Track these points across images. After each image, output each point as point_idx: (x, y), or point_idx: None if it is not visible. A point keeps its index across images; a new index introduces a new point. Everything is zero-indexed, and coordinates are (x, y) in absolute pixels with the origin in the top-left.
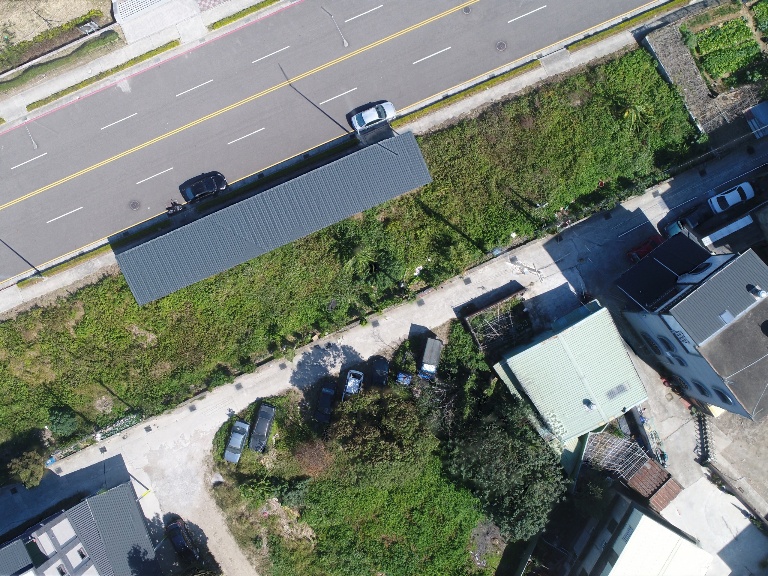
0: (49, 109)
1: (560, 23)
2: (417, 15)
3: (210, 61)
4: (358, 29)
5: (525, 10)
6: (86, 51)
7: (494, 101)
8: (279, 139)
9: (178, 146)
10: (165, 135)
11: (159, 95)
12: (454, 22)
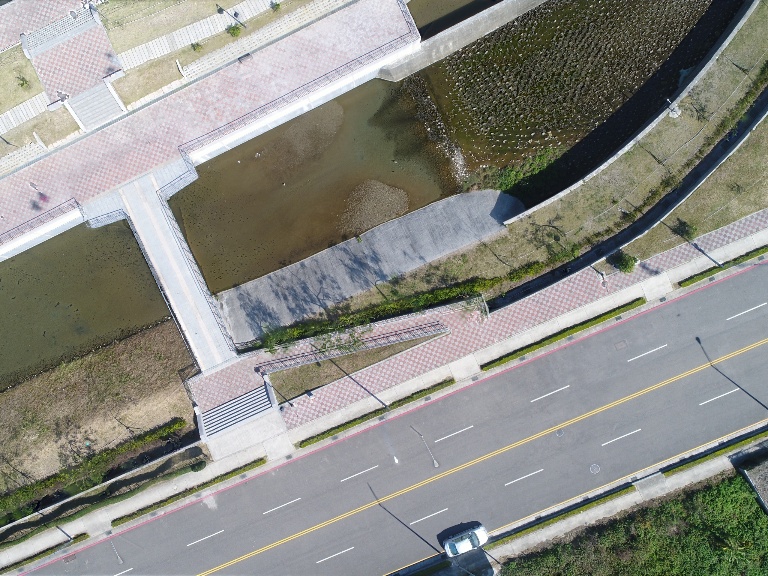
0: (134, 524)
1: (655, 446)
2: (509, 436)
3: (297, 479)
4: (448, 450)
5: (619, 433)
6: (173, 477)
7: (588, 525)
8: (369, 558)
9: (266, 564)
10: (253, 553)
11: (246, 512)
12: (547, 444)
